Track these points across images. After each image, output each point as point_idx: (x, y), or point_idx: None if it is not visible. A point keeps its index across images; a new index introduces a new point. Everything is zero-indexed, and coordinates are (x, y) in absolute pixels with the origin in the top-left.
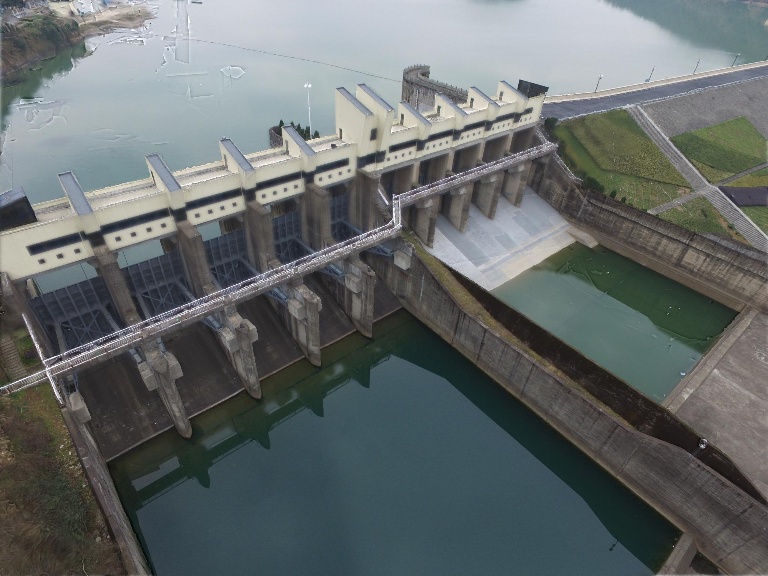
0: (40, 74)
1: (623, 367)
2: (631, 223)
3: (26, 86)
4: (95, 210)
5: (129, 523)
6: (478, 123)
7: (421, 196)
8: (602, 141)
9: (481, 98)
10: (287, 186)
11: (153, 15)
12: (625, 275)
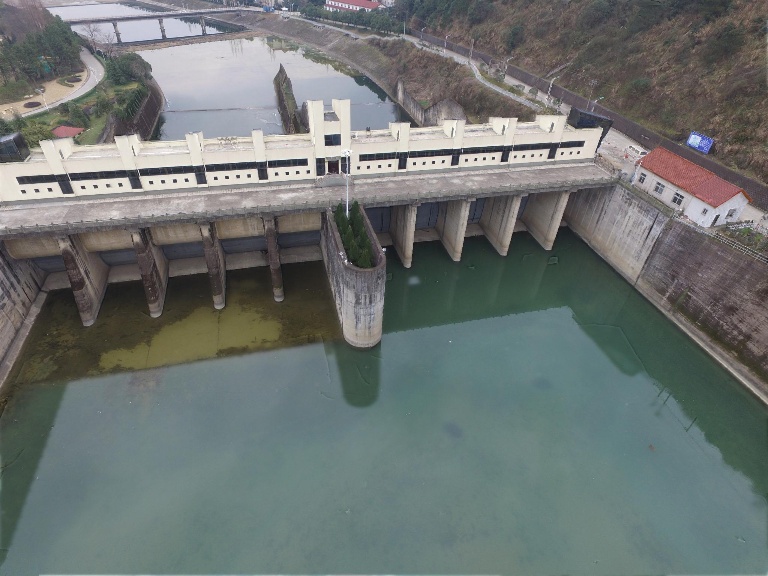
0: None
1: None
2: None
3: None
4: (539, 121)
5: None
6: None
7: None
8: None
9: None
10: None
11: None
12: None
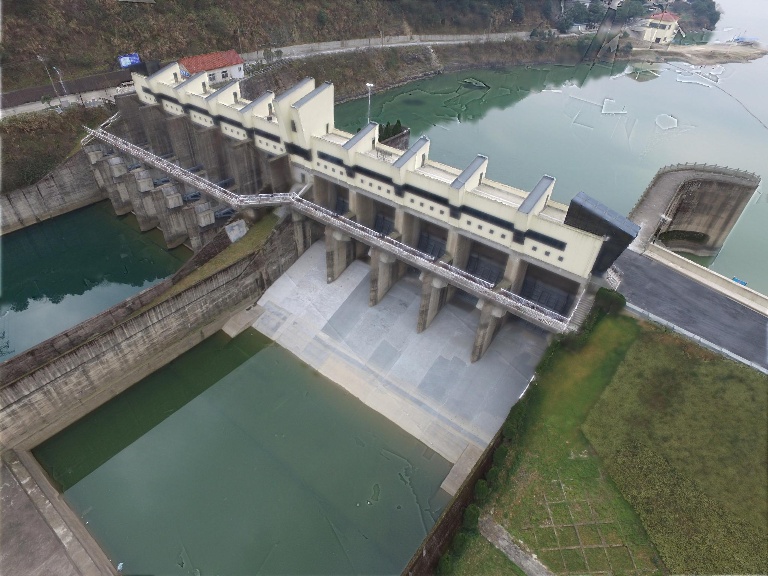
0: (546, 75)
1: (145, 479)
2: None
3: (524, 79)
4: (158, 82)
5: (58, 206)
6: (439, 197)
7: (313, 214)
8: (678, 412)
9: None
10: (239, 131)
11: (747, 60)
12: None
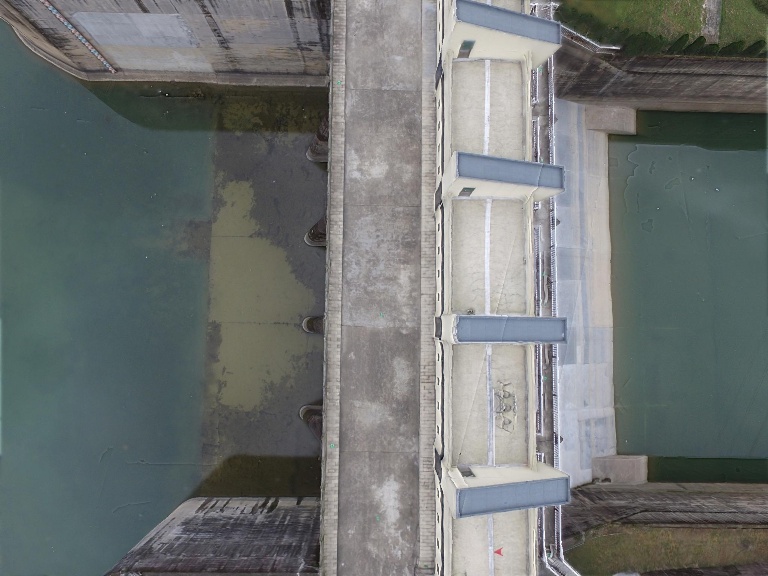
0: None
1: None
2: (714, 78)
3: None
4: None
5: None
6: None
7: None
8: None
9: (507, 187)
10: None
11: None
12: (675, 125)
